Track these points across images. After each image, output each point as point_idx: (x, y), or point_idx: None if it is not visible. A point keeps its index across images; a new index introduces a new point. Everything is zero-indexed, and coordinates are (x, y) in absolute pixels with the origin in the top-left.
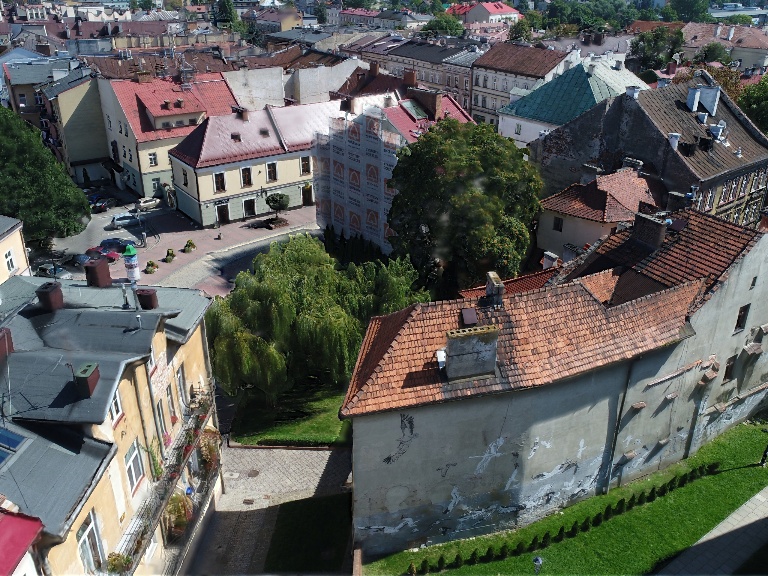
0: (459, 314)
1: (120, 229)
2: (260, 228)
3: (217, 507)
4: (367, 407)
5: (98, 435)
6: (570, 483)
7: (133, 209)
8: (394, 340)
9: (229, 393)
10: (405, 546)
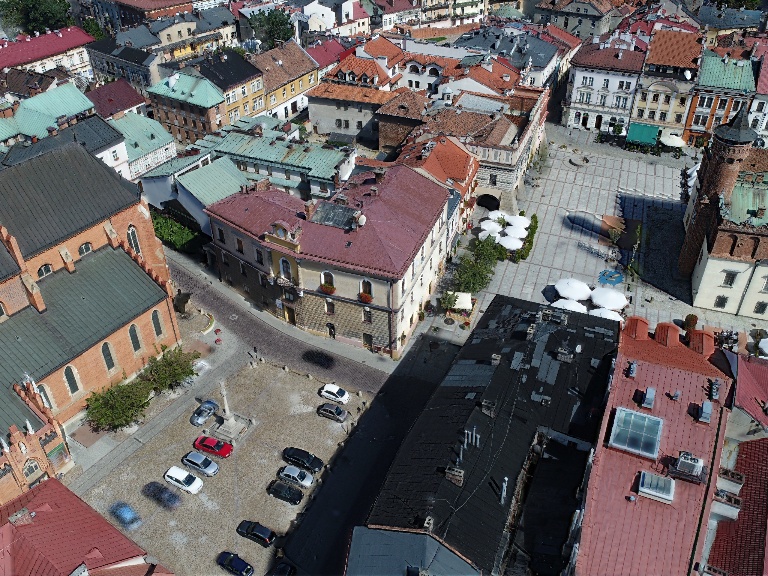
0: None
1: None
2: None
3: None
4: None
5: None
6: None
7: None
8: None
9: None
10: None
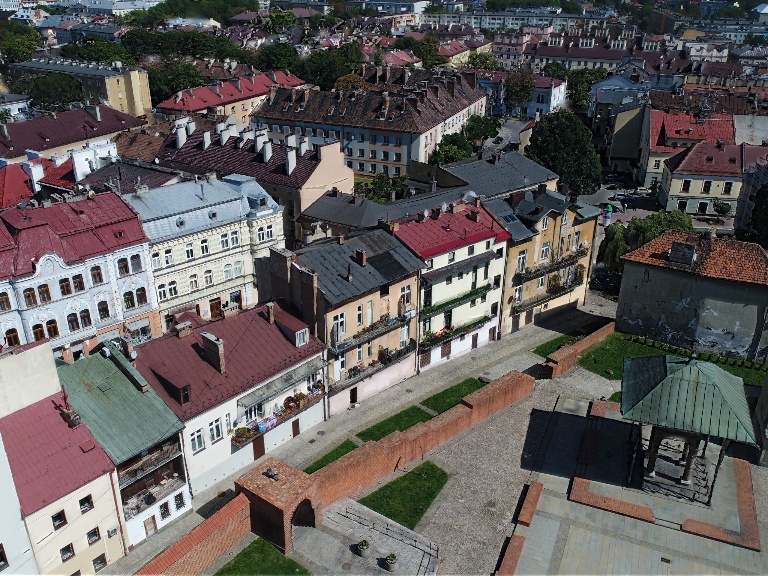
0: (688, 238)
1: (617, 201)
2: (703, 222)
3: (578, 307)
4: (631, 258)
5: (536, 228)
6: (729, 343)
7: (633, 193)
8: (654, 239)
9: (609, 272)
10: (636, 334)
